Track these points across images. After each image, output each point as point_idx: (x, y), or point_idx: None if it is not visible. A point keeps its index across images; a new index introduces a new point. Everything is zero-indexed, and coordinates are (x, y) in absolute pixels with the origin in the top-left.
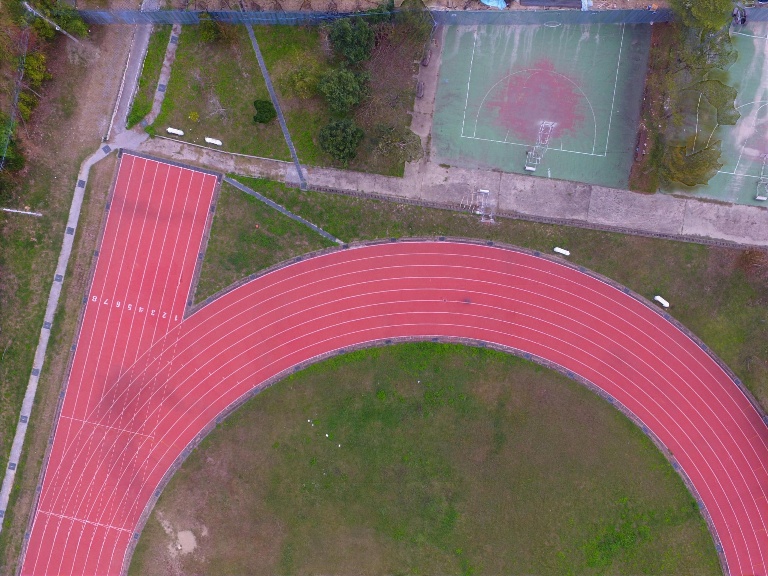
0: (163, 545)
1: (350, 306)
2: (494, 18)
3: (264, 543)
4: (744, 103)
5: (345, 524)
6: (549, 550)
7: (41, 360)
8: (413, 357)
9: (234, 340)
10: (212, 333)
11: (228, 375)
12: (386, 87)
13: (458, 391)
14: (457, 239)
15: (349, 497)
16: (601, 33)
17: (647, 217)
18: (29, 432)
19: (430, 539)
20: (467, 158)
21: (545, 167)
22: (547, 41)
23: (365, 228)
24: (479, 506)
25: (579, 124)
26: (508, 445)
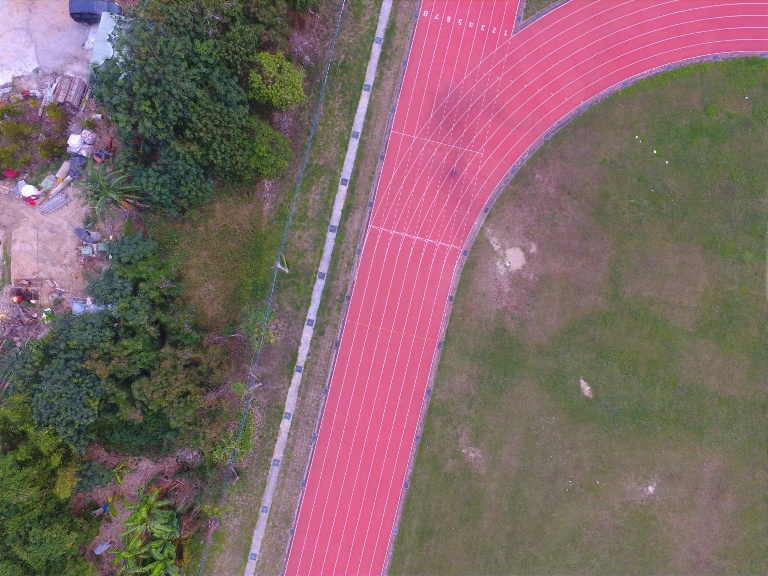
0: (492, 262)
1: (678, 21)
2: None
3: (592, 260)
4: None
5: (672, 241)
6: None
7: (372, 76)
8: (741, 72)
9: (563, 56)
10: (541, 49)
11: (556, 91)
12: None
13: None
14: None
15: (677, 214)
16: None
17: None
18: (361, 148)
19: (758, 256)
20: None
21: None
22: None
23: None
24: None
25: None
26: None
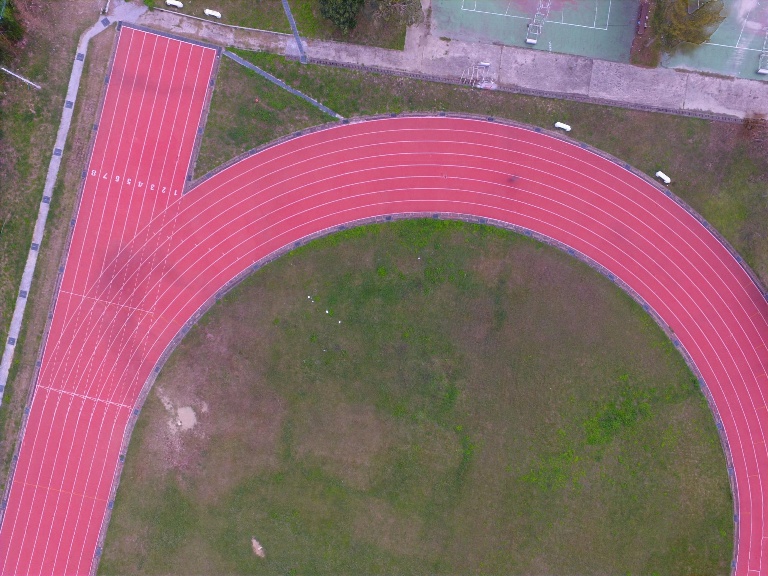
0: (163, 421)
1: (350, 182)
2: None
3: (264, 419)
4: None
5: (345, 401)
6: (550, 427)
7: (40, 235)
8: (413, 233)
9: (234, 215)
10: (212, 208)
11: (228, 251)
12: None
13: (458, 268)
14: (458, 115)
15: (349, 374)
16: None
17: (649, 91)
18: (28, 307)
19: (430, 416)
20: (468, 31)
21: (546, 40)
22: None
23: (365, 103)
24: (479, 383)
25: None
26: (509, 322)
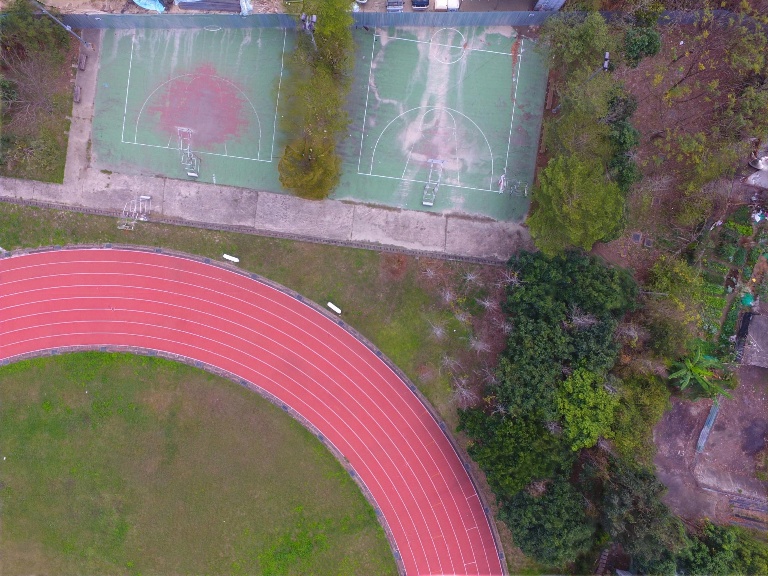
0: None
1: (13, 315)
2: (145, 22)
3: None
4: (410, 108)
5: (12, 539)
6: (224, 561)
7: None
8: (80, 367)
9: None
10: None
11: None
12: (44, 92)
13: (128, 401)
14: (125, 246)
15: (15, 511)
16: (263, 37)
17: (315, 223)
18: None
19: (100, 552)
20: (129, 164)
21: (210, 173)
22: (208, 45)
23: (27, 236)
24: (151, 518)
25: (244, 129)
26: (180, 455)
